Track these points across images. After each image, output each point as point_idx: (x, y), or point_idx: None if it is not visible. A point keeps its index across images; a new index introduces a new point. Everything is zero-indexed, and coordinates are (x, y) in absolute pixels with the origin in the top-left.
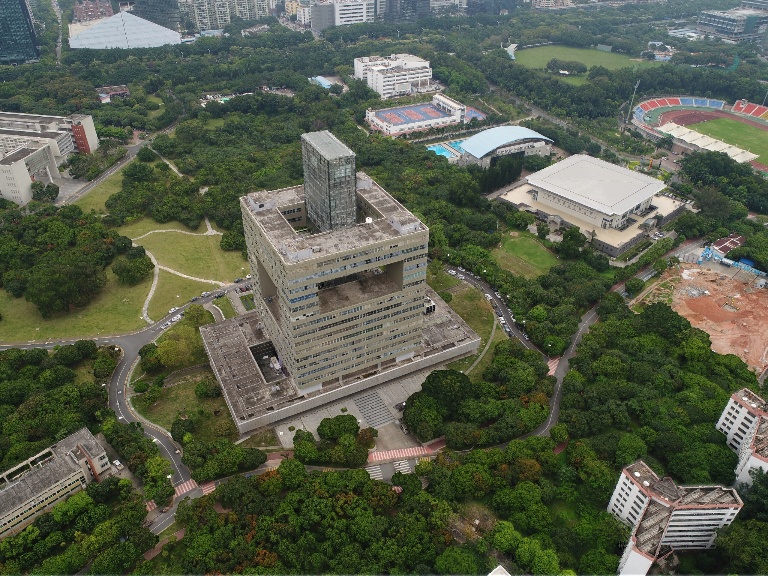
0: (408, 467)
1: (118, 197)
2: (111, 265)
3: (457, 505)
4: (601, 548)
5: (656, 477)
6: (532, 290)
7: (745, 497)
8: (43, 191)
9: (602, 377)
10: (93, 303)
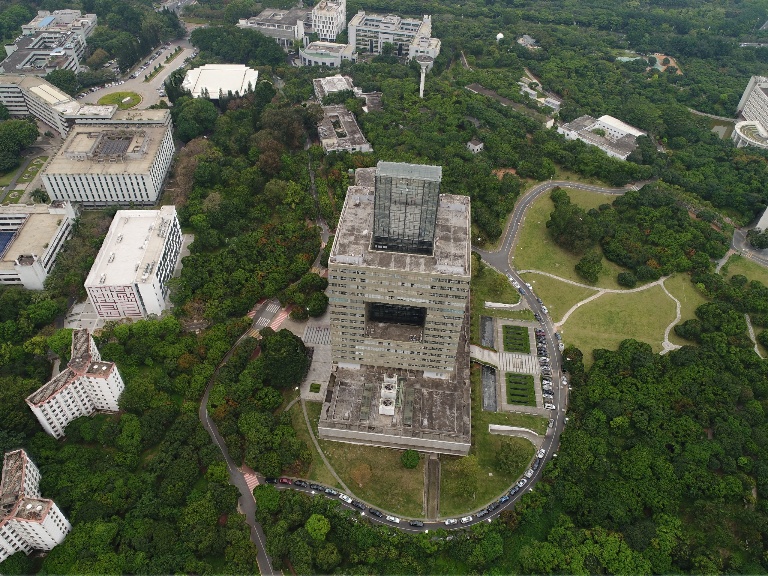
0: (260, 324)
1: (756, 287)
2: (617, 266)
3: (211, 322)
4: (116, 360)
5: (91, 375)
6: (364, 570)
7: (29, 456)
8: (762, 236)
9: (197, 495)
10: (562, 250)
